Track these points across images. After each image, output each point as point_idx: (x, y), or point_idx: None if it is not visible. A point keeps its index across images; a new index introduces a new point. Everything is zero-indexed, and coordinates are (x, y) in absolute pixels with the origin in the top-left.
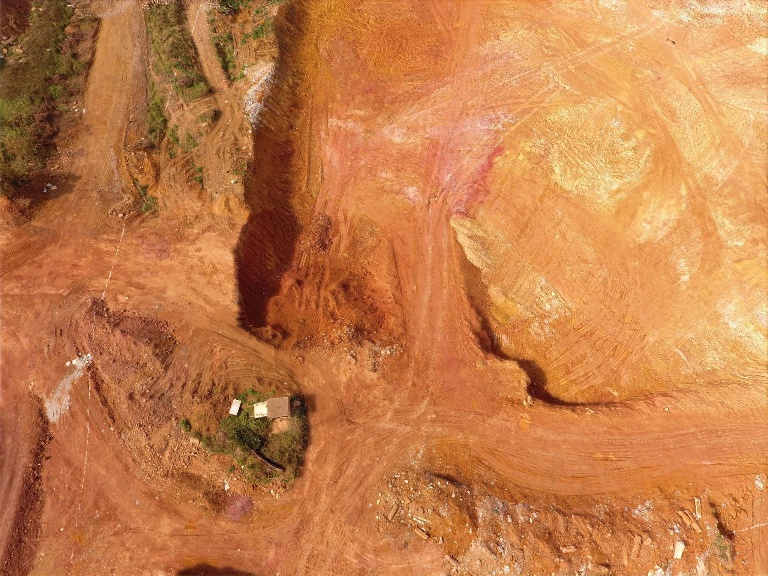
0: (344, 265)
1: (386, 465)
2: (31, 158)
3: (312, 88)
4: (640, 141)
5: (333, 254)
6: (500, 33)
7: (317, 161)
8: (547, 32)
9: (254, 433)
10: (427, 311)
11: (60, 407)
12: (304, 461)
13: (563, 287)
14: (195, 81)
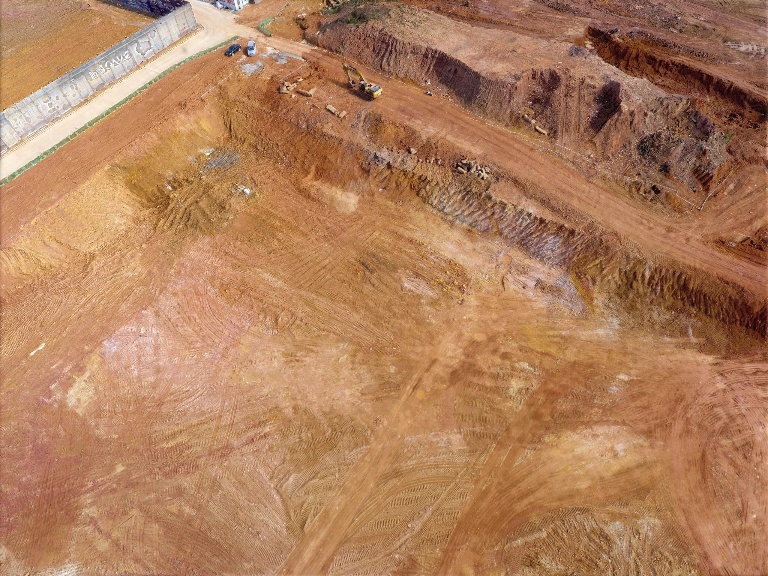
0: None
1: None
2: None
3: None
4: (508, 570)
5: None
6: None
7: None
8: None
9: None
10: None
11: None
12: None
13: None
14: None
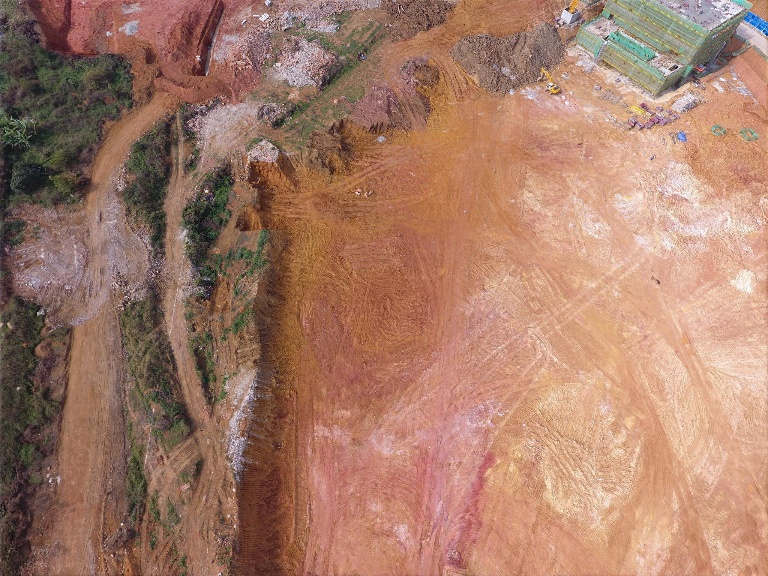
0: None
1: None
2: (4, 574)
3: (296, 381)
4: (630, 433)
5: None
6: (485, 282)
7: (304, 494)
8: (532, 277)
9: None
10: None
11: None
12: None
13: None
14: (175, 421)
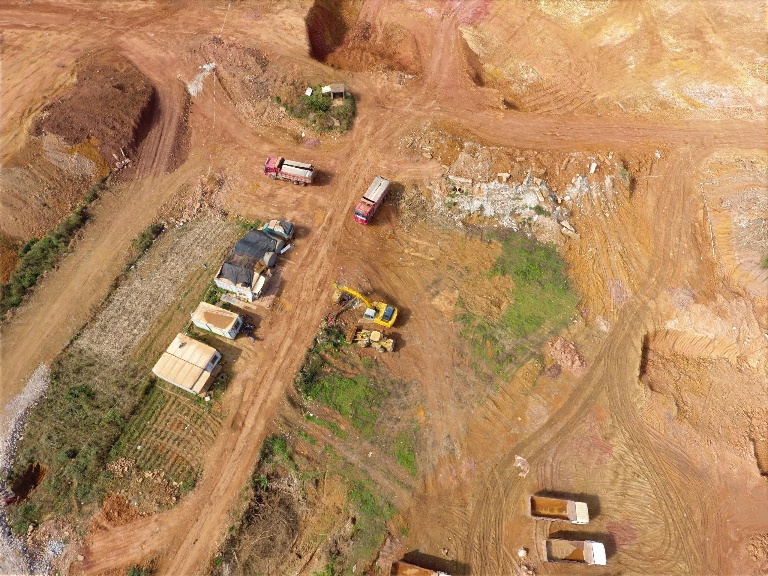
0: (379, 48)
1: (406, 128)
2: None
3: None
4: None
5: (371, 42)
6: None
7: None
8: None
9: (321, 103)
10: (438, 65)
11: (197, 88)
12: (353, 123)
13: (538, 67)
14: None
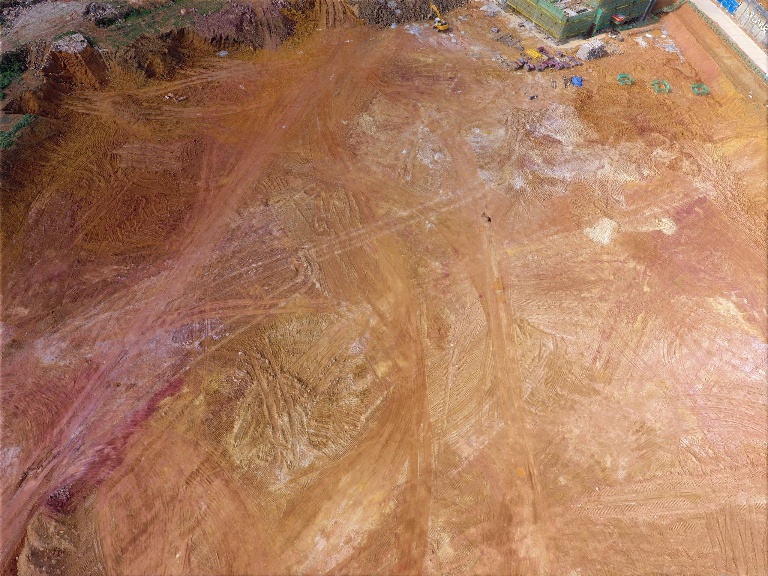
0: None
1: None
2: None
3: None
4: (377, 380)
5: None
6: (271, 196)
7: None
8: (332, 197)
9: None
10: None
11: None
12: None
13: None
14: None
